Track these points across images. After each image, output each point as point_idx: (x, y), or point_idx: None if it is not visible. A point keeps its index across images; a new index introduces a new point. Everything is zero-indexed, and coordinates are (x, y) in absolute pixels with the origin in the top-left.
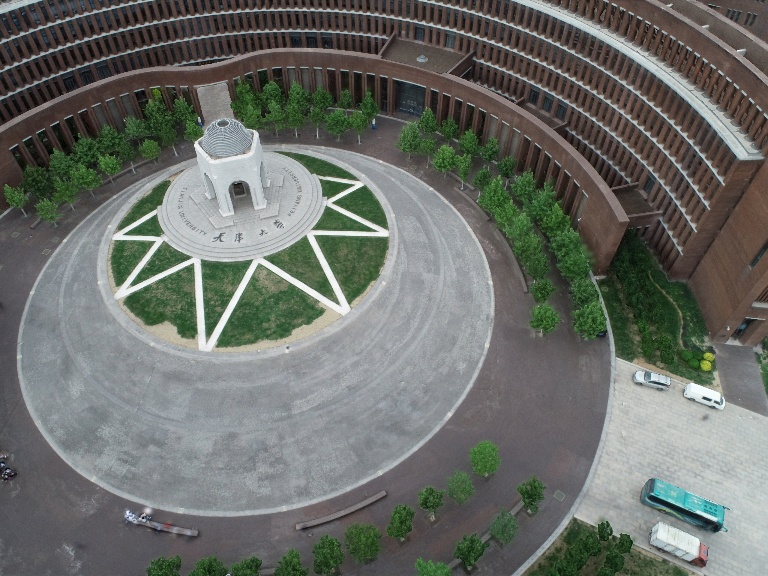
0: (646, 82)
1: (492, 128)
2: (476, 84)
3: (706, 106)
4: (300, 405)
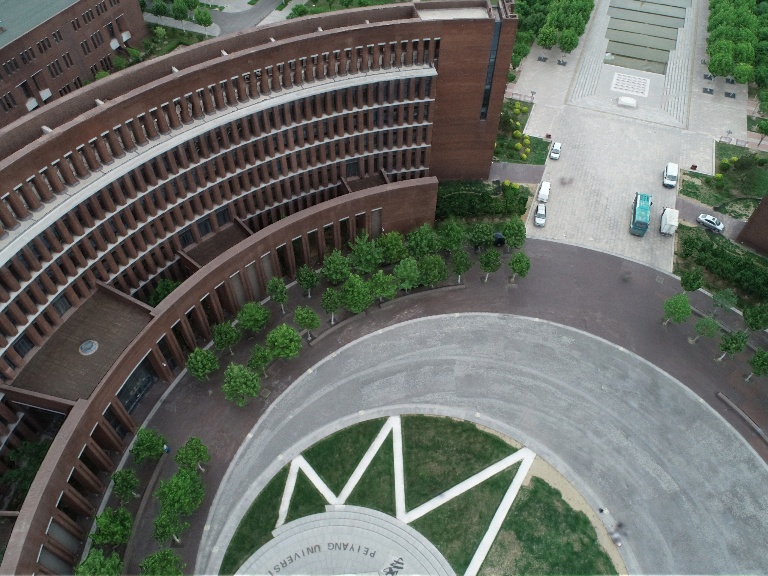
0: (298, 110)
1: (235, 287)
2: (189, 278)
3: (365, 76)
4: (667, 483)
